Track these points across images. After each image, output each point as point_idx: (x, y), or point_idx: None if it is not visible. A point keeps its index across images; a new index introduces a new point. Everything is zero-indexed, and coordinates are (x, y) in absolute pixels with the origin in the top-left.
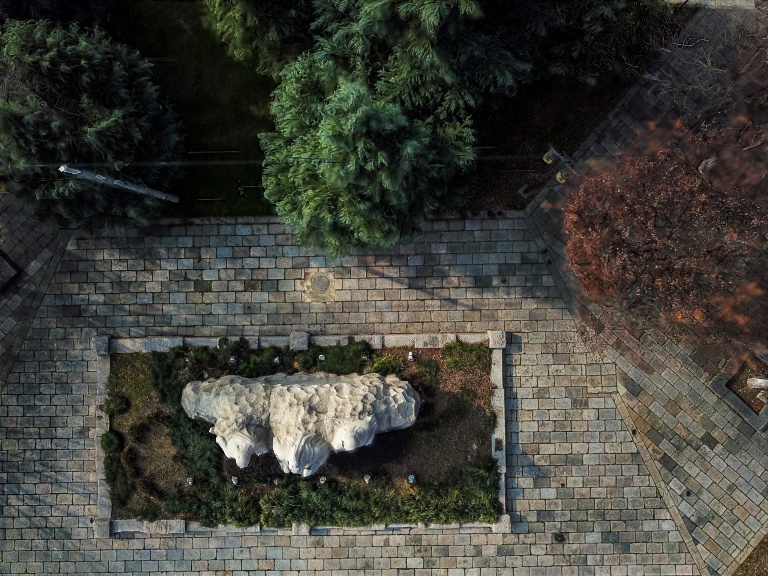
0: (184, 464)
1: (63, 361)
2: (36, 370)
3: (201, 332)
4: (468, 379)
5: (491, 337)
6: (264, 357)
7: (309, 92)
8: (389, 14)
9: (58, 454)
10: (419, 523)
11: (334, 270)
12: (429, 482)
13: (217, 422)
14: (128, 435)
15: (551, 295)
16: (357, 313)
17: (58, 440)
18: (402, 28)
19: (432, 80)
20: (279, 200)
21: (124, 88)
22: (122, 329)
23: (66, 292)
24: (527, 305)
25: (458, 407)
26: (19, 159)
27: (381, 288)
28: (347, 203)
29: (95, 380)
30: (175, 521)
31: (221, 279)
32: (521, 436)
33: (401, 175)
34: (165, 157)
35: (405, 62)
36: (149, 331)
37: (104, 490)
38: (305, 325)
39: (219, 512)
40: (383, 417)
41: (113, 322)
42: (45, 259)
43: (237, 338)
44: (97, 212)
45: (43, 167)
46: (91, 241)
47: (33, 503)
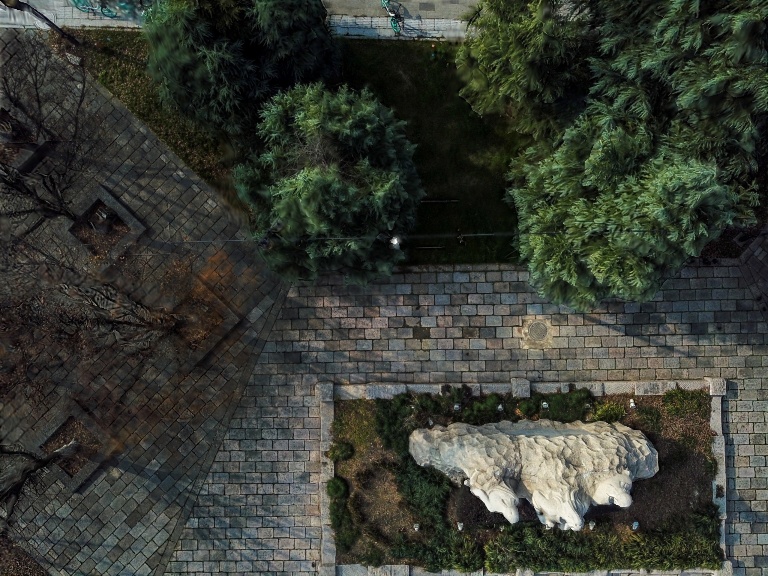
0: (410, 510)
1: (284, 407)
2: (258, 416)
3: (420, 378)
4: (689, 426)
5: (712, 385)
6: (488, 404)
7: (609, 160)
8: (721, 91)
9: (280, 499)
10: (641, 569)
11: (551, 317)
12: (651, 528)
13: (473, 475)
14: (354, 481)
15: (766, 342)
16: (574, 360)
17: (279, 485)
18: (718, 101)
19: (722, 146)
20: (548, 259)
21: (392, 148)
22: (342, 375)
23: (287, 339)
24: (743, 352)
25: (680, 454)
26: (318, 224)
27: (598, 335)
28: (636, 266)
29: (316, 426)
30: (399, 566)
31: (439, 326)
32: (738, 482)
33: (706, 242)
34: (411, 211)
35: (701, 130)
36: (369, 377)
37: (328, 535)
38: (523, 372)
39: (445, 558)
40: (634, 469)
41: (333, 368)
42: (266, 306)
43: (460, 385)
44: (344, 266)
45: (328, 229)
46: (311, 289)
47: (255, 547)
